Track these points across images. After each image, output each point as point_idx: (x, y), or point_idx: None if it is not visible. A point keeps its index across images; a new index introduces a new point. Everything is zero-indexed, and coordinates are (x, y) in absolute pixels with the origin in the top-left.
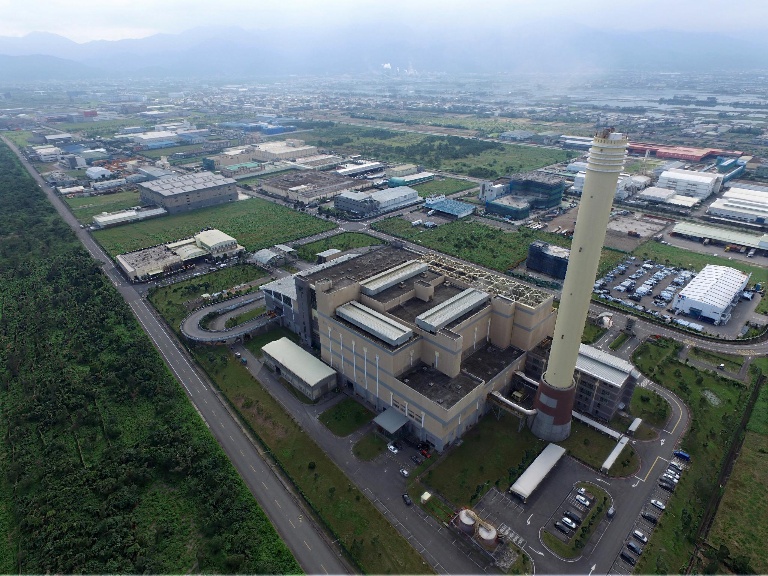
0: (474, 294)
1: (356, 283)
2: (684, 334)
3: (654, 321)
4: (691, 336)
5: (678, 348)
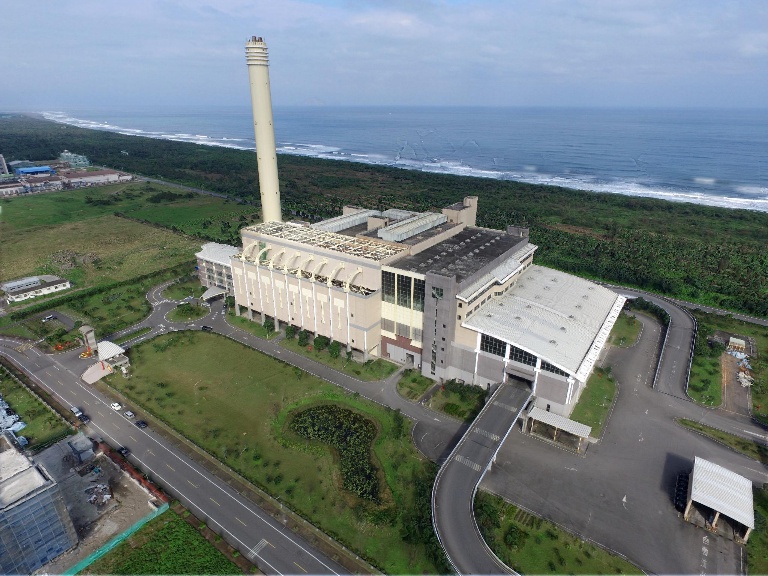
0: (326, 225)
1: (445, 208)
2: (7, 358)
3: (16, 373)
4: (3, 356)
5: (65, 331)
